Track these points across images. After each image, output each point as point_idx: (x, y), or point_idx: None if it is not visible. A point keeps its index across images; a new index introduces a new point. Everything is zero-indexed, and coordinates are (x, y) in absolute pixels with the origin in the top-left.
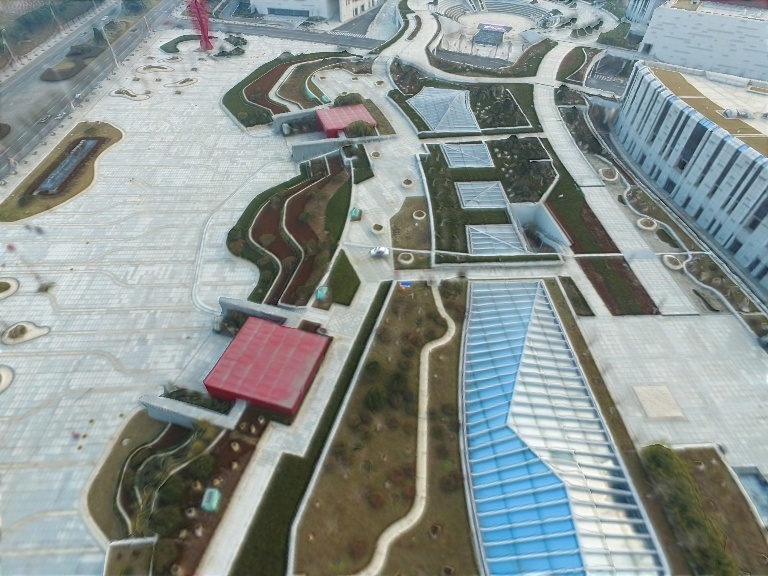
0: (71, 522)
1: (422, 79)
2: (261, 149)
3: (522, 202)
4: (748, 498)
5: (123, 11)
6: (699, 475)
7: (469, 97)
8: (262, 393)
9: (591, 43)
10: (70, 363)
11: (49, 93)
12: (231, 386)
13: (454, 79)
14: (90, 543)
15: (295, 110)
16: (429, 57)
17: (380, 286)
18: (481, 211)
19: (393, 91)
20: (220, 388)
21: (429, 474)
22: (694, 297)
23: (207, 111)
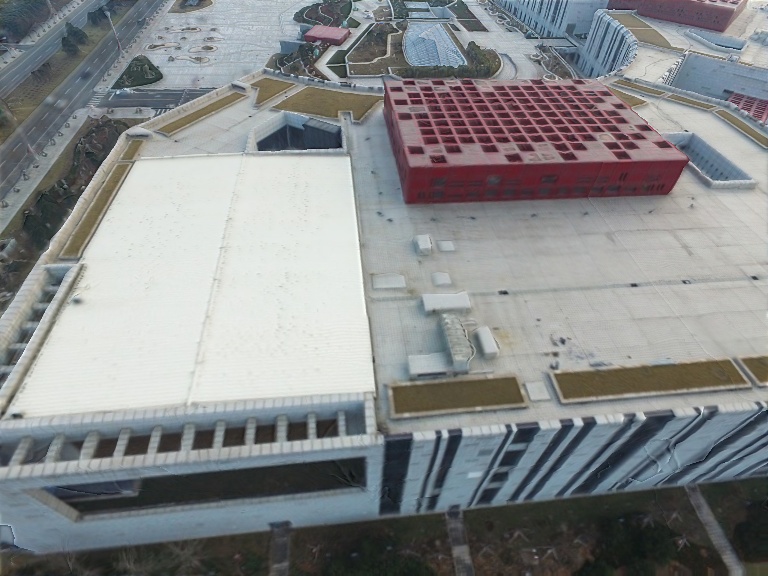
0: None
1: None
2: None
3: (436, 7)
4: (499, 55)
5: None
6: (485, 52)
7: None
8: (328, 36)
9: None
10: None
11: None
12: (315, 35)
13: None
14: None
15: None
16: None
17: None
18: (416, 9)
19: None
20: (311, 35)
21: None
22: (505, 29)
23: None
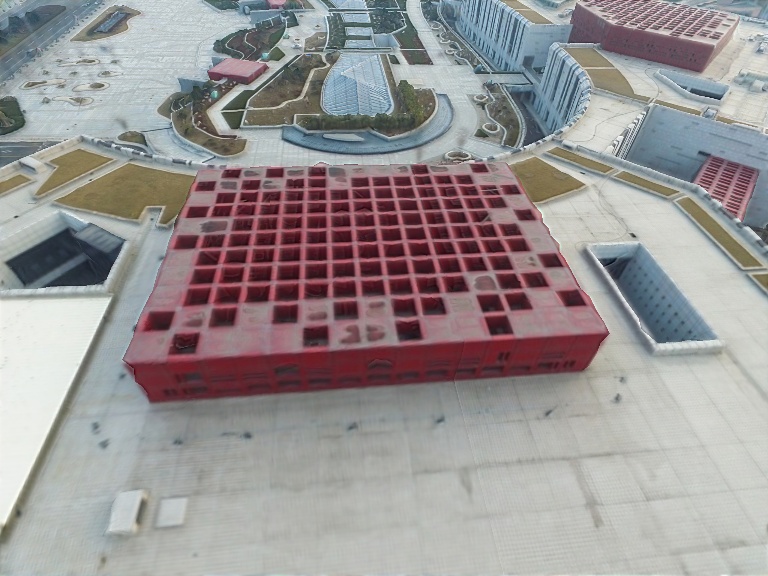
0: (152, 116)
1: None
2: (231, 19)
3: (380, 33)
4: (435, 96)
5: None
6: (419, 93)
7: None
8: (235, 73)
9: None
10: (137, 82)
11: None
12: (220, 72)
13: None
14: None
15: None
16: None
17: (295, 56)
18: (356, 36)
19: None
20: (215, 72)
21: (307, 92)
22: (454, 62)
23: (194, 4)
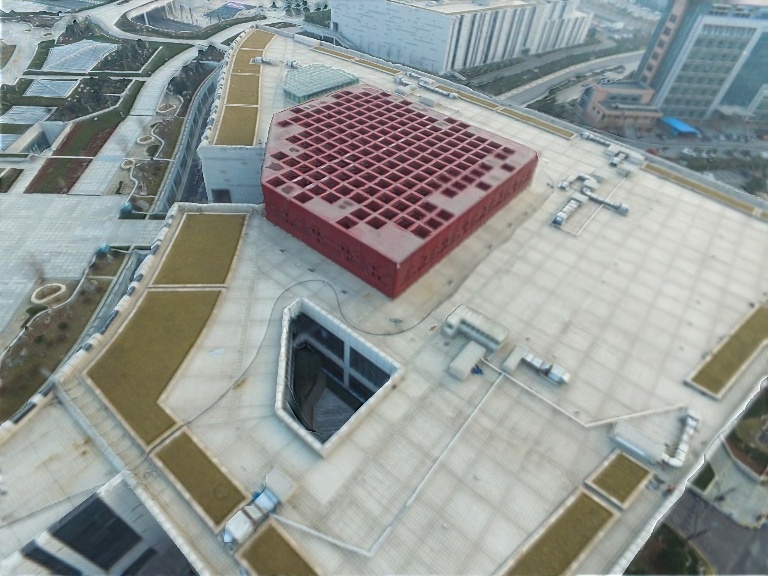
0: None
1: (91, 34)
2: None
3: (53, 121)
4: None
5: None
6: None
7: (116, 49)
8: None
9: (299, 21)
10: None
11: None
12: None
13: (123, 36)
14: None
15: None
16: (119, 19)
17: None
18: (7, 125)
19: (48, 41)
20: None
21: None
22: (115, 186)
23: None
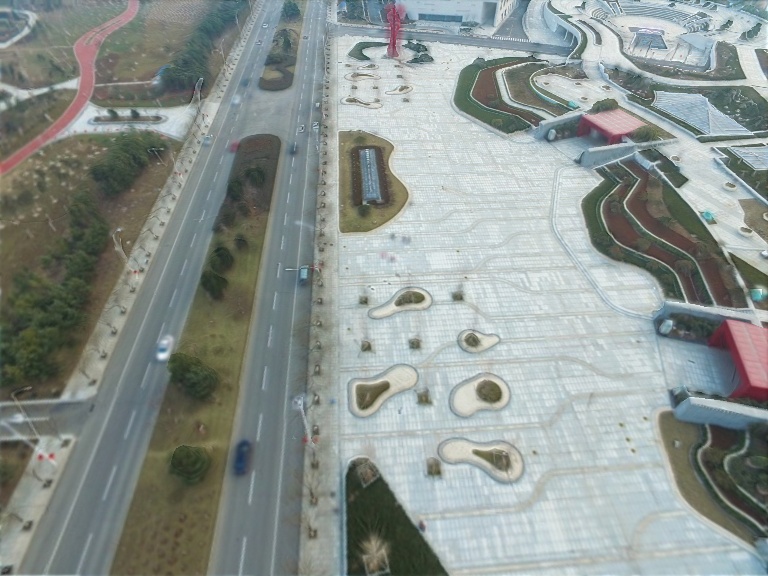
0: (689, 522)
1: None
2: (538, 155)
3: None
4: None
5: (283, 19)
6: None
7: None
8: None
9: (764, 45)
10: (549, 369)
11: (282, 102)
12: None
13: (674, 83)
14: (724, 541)
15: (546, 116)
16: (633, 61)
17: None
18: None
19: (630, 96)
20: None
21: None
22: None
23: (450, 118)
